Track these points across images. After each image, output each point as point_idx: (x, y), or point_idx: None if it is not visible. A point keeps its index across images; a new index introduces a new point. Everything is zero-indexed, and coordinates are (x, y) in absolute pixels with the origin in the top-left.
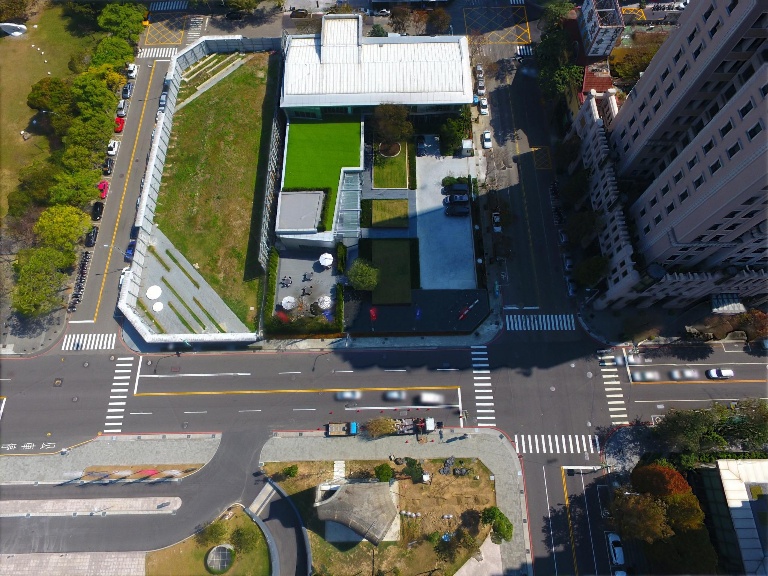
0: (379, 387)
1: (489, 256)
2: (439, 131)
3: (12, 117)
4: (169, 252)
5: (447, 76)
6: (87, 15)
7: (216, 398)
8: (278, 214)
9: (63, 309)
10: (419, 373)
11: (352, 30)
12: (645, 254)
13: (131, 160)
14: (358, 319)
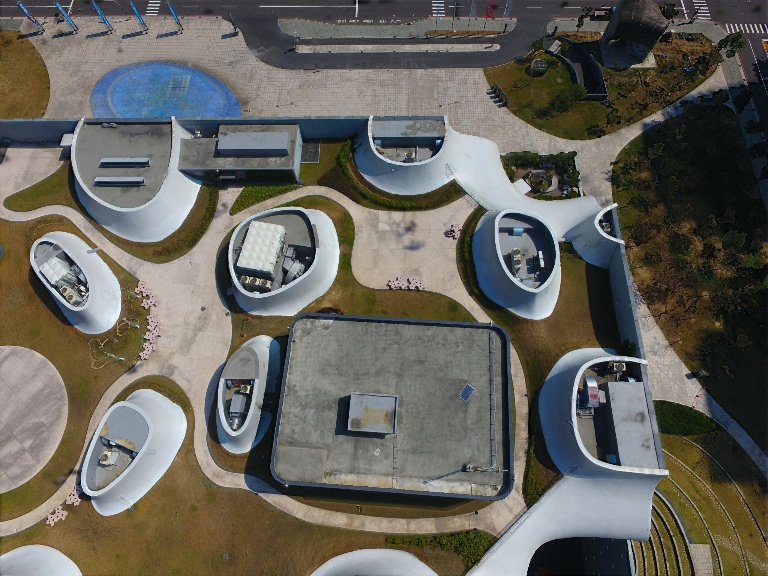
0: None
1: None
2: None
3: None
4: None
5: None
6: None
7: (508, 0)
8: None
9: None
10: None
11: None
12: None
13: None
14: None
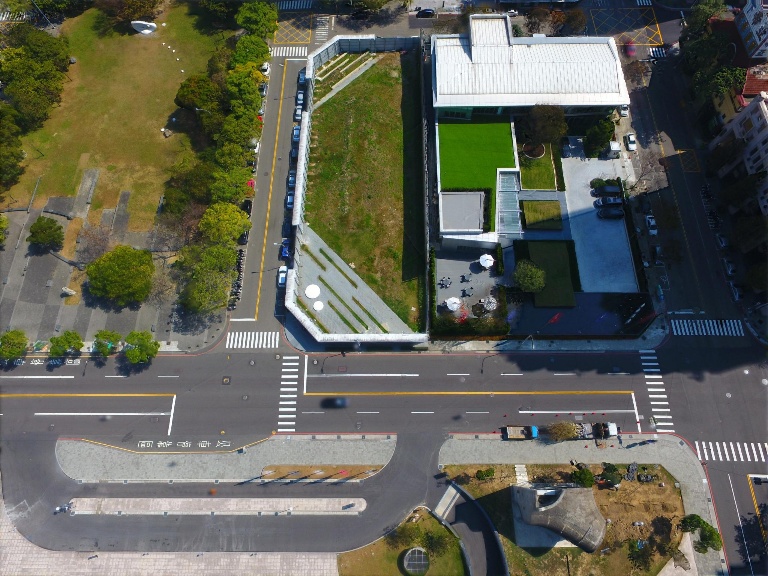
0: (551, 390)
1: (647, 259)
2: (582, 133)
3: (151, 114)
4: (323, 251)
5: (602, 77)
6: (221, 13)
7: (387, 399)
8: (441, 214)
9: (223, 307)
10: (590, 377)
11: (501, 30)
12: None
13: (274, 158)
14: (522, 321)
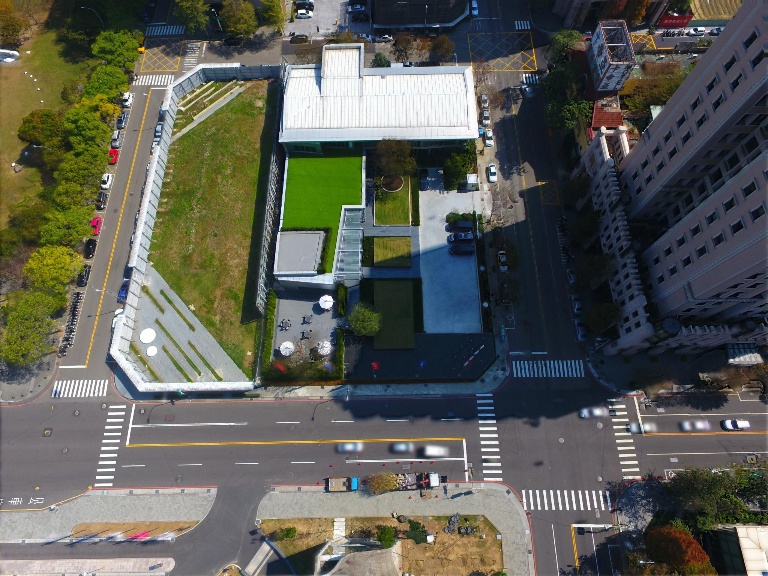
0: (381, 438)
1: (495, 297)
2: (443, 164)
3: (3, 148)
4: (164, 292)
5: (451, 110)
6: (81, 42)
7: (211, 450)
8: (276, 255)
9: (53, 353)
10: (422, 423)
11: (353, 61)
12: (659, 304)
13: (125, 194)
14: (359, 365)
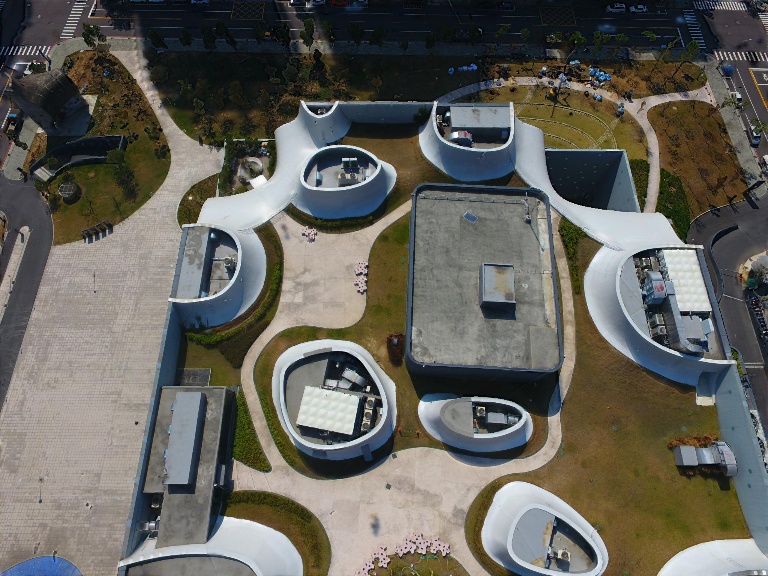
0: None
1: None
2: None
3: None
4: None
5: None
6: None
7: None
8: None
9: None
10: None
11: None
12: None
13: None
14: None
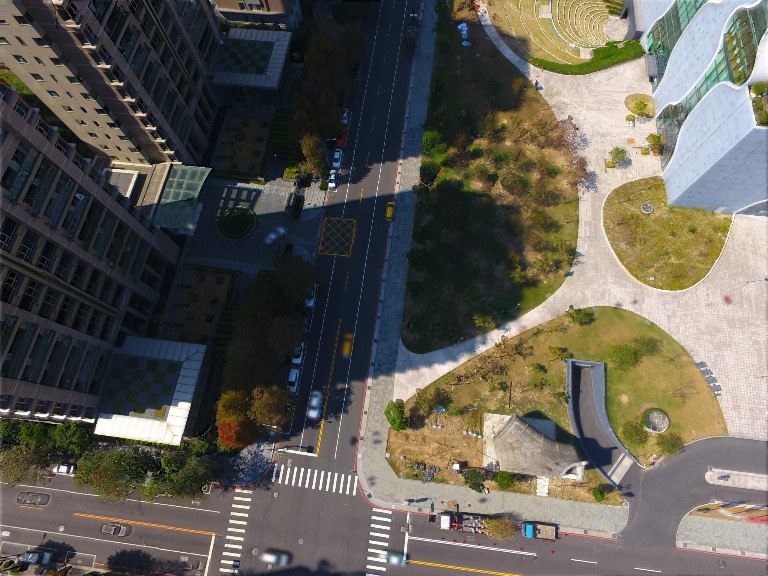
0: None
1: None
2: None
3: None
4: None
5: None
6: None
7: None
8: None
9: None
10: None
11: None
12: None
13: None
14: None
